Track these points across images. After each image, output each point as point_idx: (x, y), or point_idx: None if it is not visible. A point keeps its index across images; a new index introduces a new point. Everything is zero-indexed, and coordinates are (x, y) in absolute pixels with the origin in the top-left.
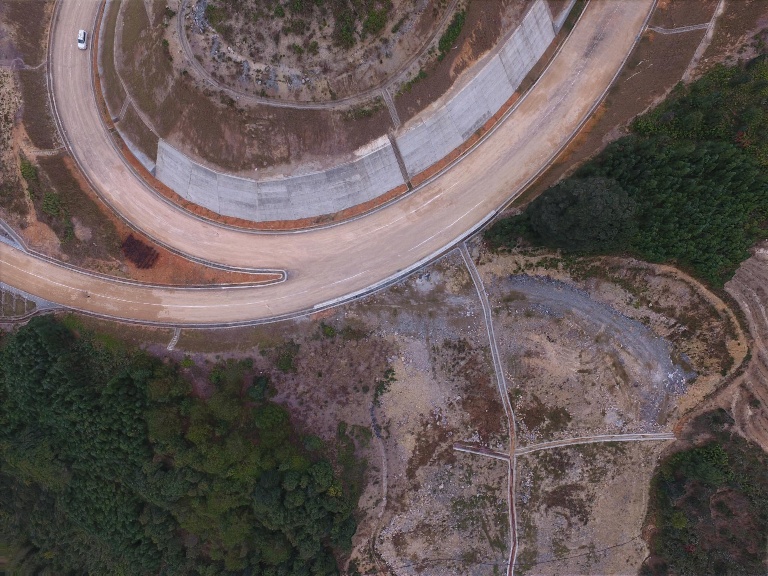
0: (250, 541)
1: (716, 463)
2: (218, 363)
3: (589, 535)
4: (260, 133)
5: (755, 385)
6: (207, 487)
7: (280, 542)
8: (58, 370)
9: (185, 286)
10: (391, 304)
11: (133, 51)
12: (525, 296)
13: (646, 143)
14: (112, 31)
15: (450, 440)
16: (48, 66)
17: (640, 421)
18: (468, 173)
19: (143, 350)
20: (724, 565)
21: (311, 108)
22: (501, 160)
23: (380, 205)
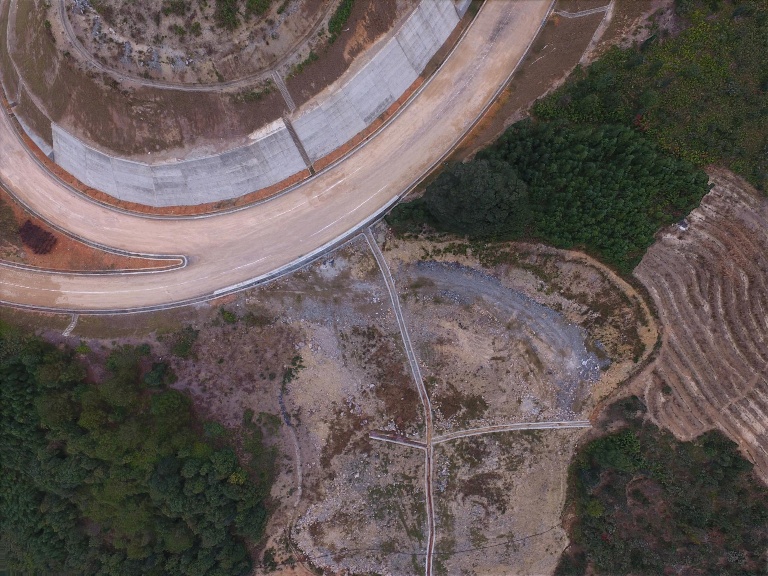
0: (151, 529)
1: (629, 450)
2: (114, 349)
3: (507, 524)
4: (149, 116)
5: (667, 372)
6: (102, 474)
7: (181, 530)
8: None
9: (84, 272)
10: (295, 290)
11: (24, 34)
12: (433, 282)
13: (543, 126)
14: (6, 14)
15: (365, 428)
16: None
17: (556, 409)
18: (372, 158)
19: (38, 336)
20: (640, 553)
21: (198, 90)
22: (405, 145)
23: (282, 190)
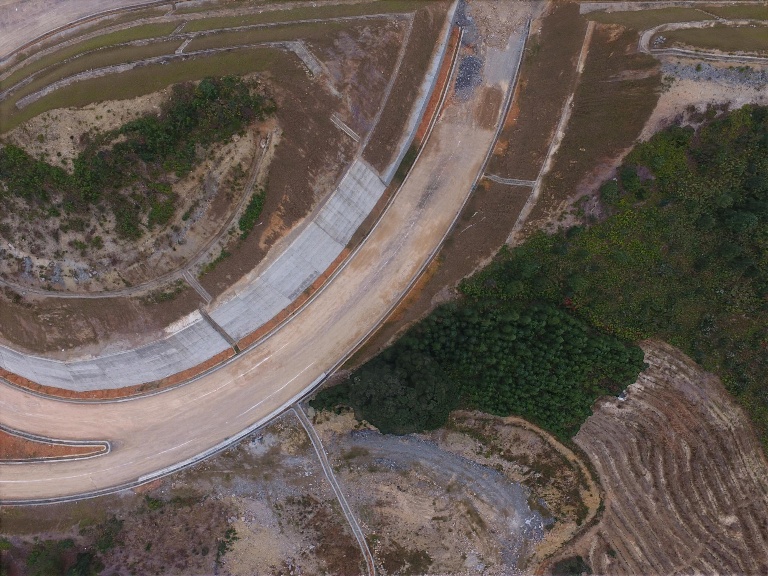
0: None
1: None
2: (37, 544)
3: None
4: (57, 321)
5: (611, 535)
6: None
7: None
8: None
9: (6, 460)
10: (223, 469)
11: None
12: (368, 451)
13: (468, 313)
14: None
15: None
16: None
17: (501, 565)
18: (298, 333)
19: None
20: None
21: (106, 297)
22: (332, 319)
23: (206, 370)
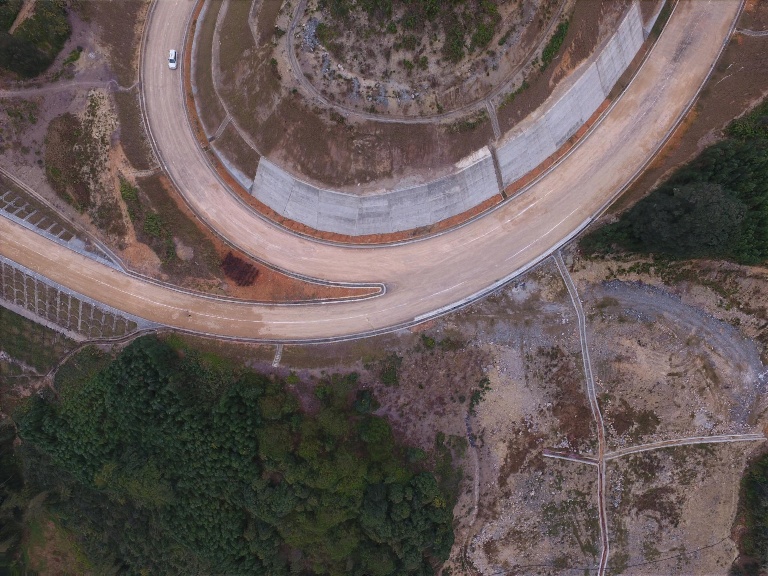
0: (356, 554)
1: None
2: (323, 378)
3: (679, 537)
4: (366, 149)
5: None
6: (317, 502)
7: (386, 554)
8: (171, 391)
9: (285, 302)
10: (488, 314)
11: (233, 70)
12: (618, 302)
13: (747, 147)
14: (208, 50)
15: (540, 447)
16: (140, 87)
17: (730, 422)
18: (562, 181)
19: (249, 368)
20: None
21: (418, 122)
22: (594, 167)
23: (476, 216)
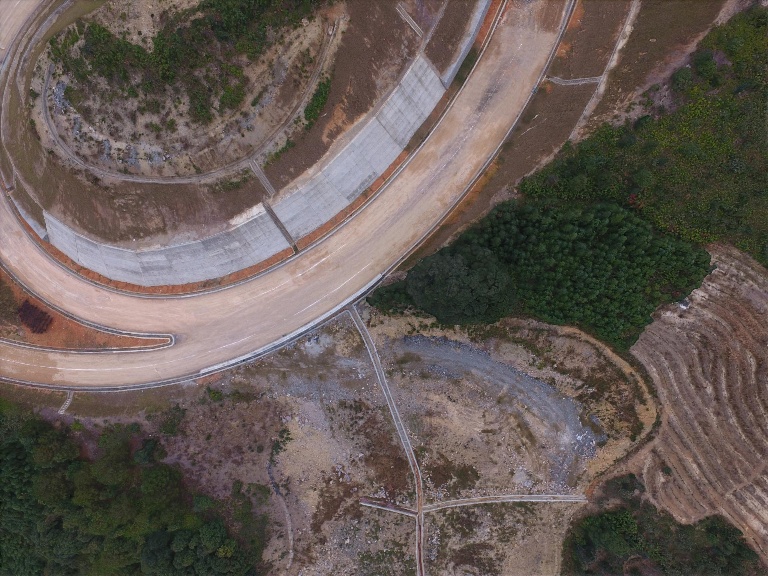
0: None
1: (625, 530)
2: (106, 427)
3: None
4: (131, 207)
5: (667, 451)
6: (97, 547)
7: None
8: None
9: (78, 350)
10: (280, 367)
11: (15, 126)
12: (420, 357)
13: (528, 208)
14: (1, 104)
15: (355, 496)
16: None
17: (550, 482)
18: (355, 235)
19: (35, 414)
20: None
21: (177, 183)
22: (389, 221)
23: (266, 269)
